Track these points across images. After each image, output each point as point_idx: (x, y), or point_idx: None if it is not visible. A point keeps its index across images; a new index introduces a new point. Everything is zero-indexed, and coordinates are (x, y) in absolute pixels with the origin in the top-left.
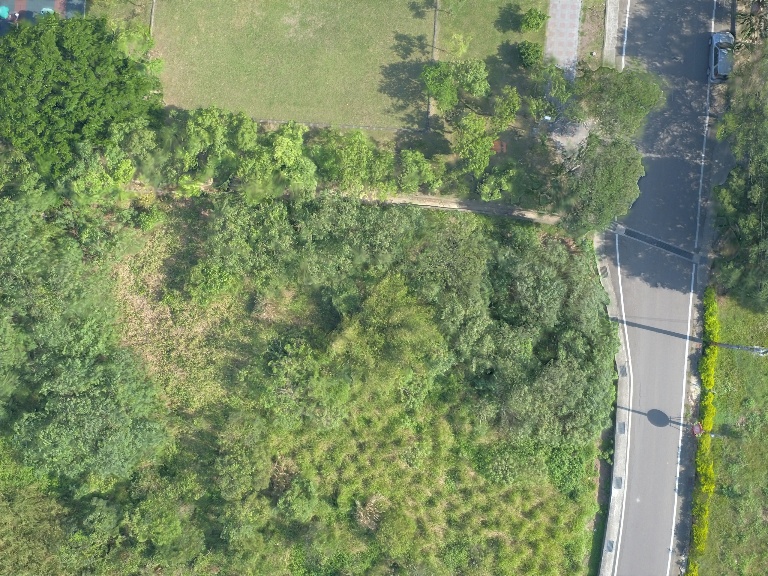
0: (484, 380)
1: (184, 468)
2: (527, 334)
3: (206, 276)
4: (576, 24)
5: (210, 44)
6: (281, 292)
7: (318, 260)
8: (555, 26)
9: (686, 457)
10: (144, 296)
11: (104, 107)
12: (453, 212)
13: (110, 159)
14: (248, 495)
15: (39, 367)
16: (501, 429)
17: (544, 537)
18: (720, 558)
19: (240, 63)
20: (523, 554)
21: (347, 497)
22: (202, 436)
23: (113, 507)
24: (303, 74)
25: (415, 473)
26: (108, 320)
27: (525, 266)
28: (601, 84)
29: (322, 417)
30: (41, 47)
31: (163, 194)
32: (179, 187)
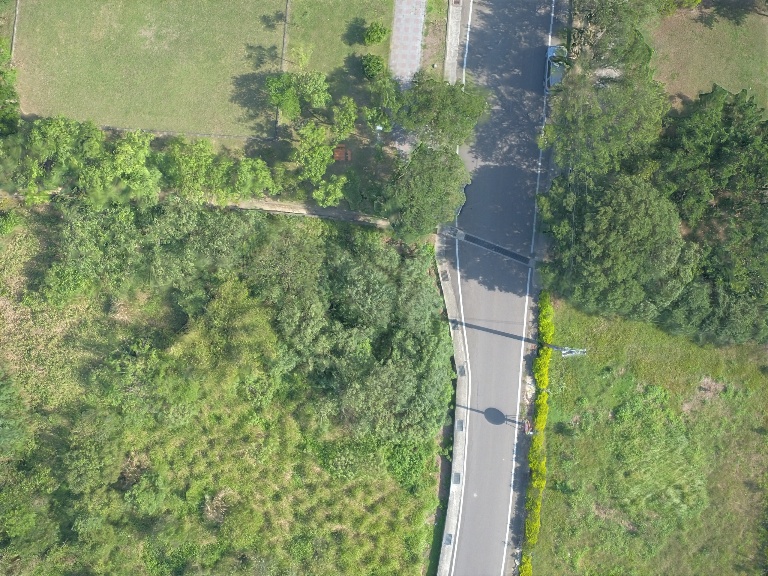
0: (326, 379)
1: (38, 463)
2: (361, 335)
3: (60, 278)
4: (419, 37)
5: (70, 55)
6: (135, 294)
7: (162, 263)
8: (399, 39)
9: (521, 454)
10: (7, 297)
11: None
12: (300, 217)
13: None
14: (97, 489)
15: None
16: (345, 426)
17: (385, 530)
18: (554, 551)
19: (98, 74)
20: (364, 546)
21: (198, 491)
22: (60, 432)
23: None
24: (158, 84)
25: (263, 468)
26: None
27: (355, 270)
28: (429, 96)
29: (169, 414)
30: None
31: (24, 199)
32: (41, 192)
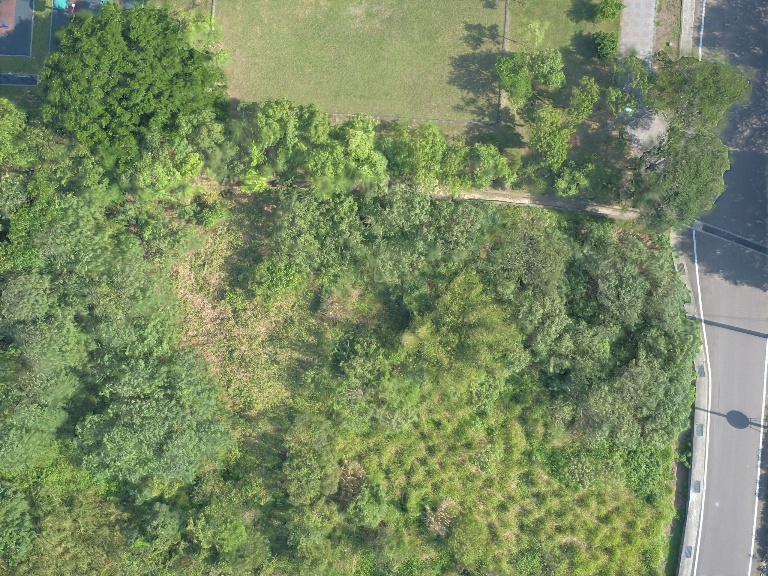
0: (559, 381)
1: (249, 472)
2: (607, 333)
3: (271, 274)
4: (651, 14)
5: (273, 35)
6: (348, 290)
7: (390, 257)
8: (630, 16)
9: (767, 460)
10: (205, 295)
11: (171, 99)
12: (525, 208)
13: (178, 153)
14: (317, 500)
15: (101, 368)
16: (575, 431)
17: (620, 543)
18: None
19: (304, 54)
20: (599, 560)
21: (416, 502)
22: (265, 439)
23: (176, 512)
24: (370, 66)
25: (486, 477)
26: (170, 319)
27: (607, 263)
28: (685, 75)
29: (392, 419)
30: (106, 37)
31: (225, 190)
32: (241, 182)
